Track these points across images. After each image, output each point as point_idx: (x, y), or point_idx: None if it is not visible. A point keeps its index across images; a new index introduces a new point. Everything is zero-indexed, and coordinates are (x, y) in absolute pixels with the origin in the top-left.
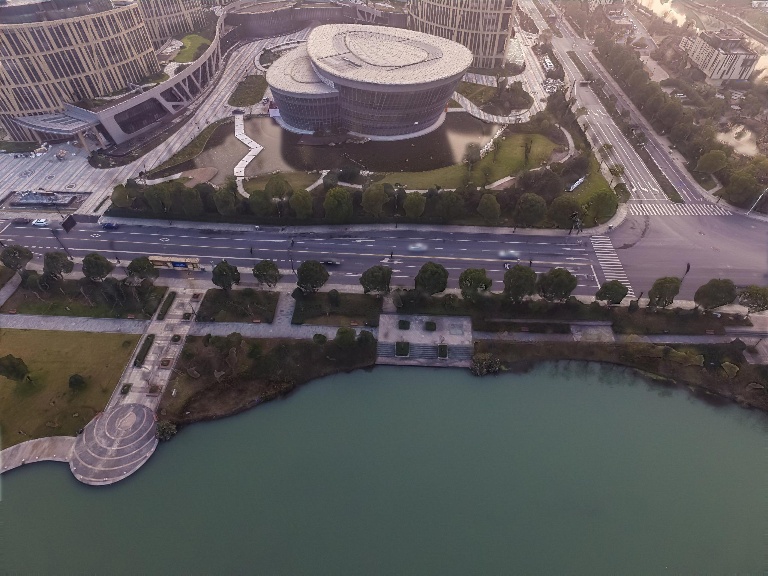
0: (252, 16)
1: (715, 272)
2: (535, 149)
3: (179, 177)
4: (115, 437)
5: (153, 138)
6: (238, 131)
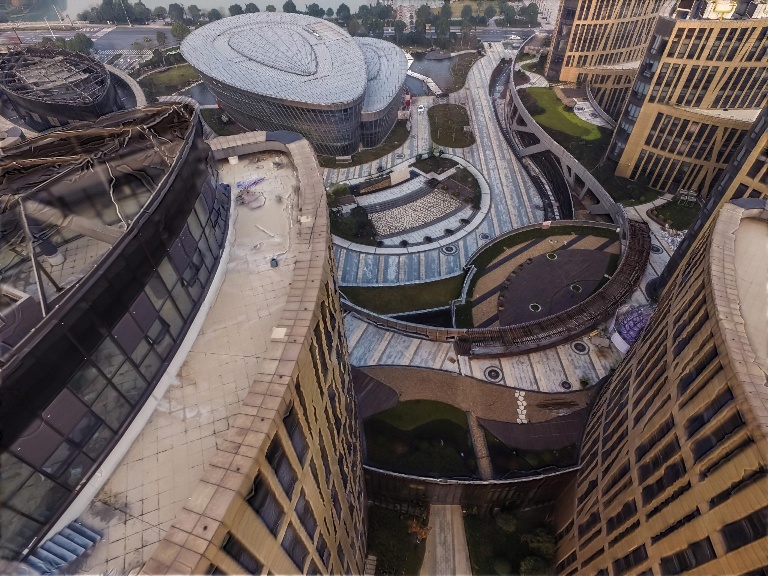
0: (550, 225)
1: (152, 34)
2: (174, 73)
3: (451, 54)
4: (407, 9)
5: (503, 73)
6: (430, 81)
